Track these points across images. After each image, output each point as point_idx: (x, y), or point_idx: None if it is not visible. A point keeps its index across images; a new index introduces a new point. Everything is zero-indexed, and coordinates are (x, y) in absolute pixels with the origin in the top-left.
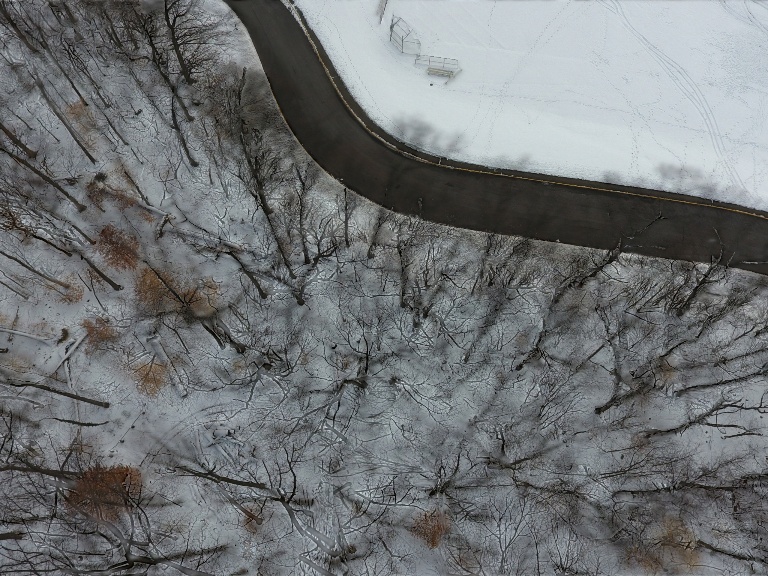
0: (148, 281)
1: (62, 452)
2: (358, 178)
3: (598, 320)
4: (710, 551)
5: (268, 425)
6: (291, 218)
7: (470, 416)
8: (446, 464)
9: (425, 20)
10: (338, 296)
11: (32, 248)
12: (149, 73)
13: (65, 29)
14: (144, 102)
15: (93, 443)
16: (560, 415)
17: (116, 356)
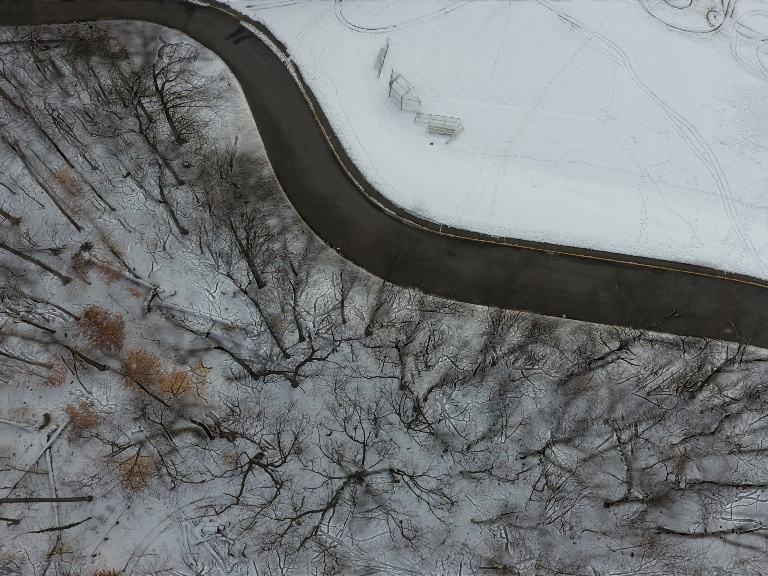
0: (134, 365)
1: (40, 564)
2: (355, 247)
3: (607, 405)
4: None
5: (259, 524)
6: (285, 293)
7: (472, 515)
8: (447, 574)
9: (425, 74)
10: (334, 378)
11: (11, 334)
12: (138, 133)
13: (49, 93)
14: (132, 164)
15: (74, 548)
16: (567, 509)
17: (100, 445)
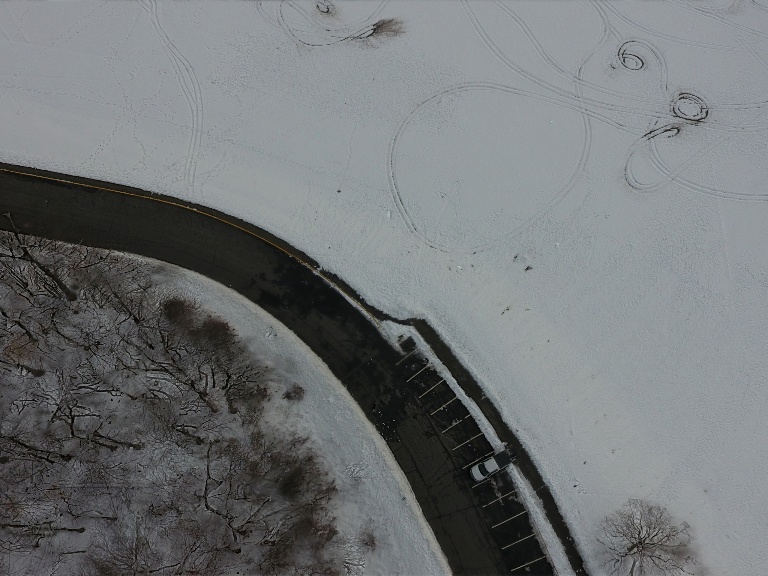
0: None
1: None
2: None
3: None
4: (3, 523)
5: None
6: None
7: None
8: None
9: None
10: None
11: None
12: None
13: None
14: None
15: None
16: None
17: None
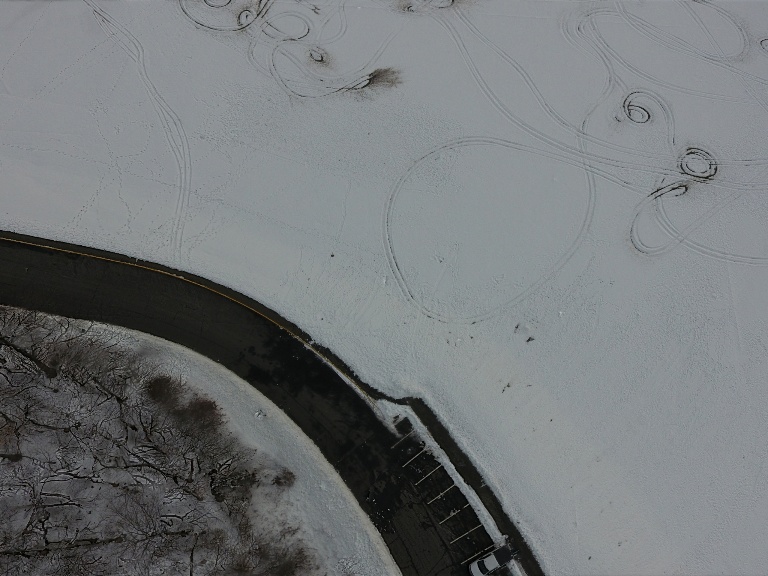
0: None
1: None
2: None
3: None
4: None
5: None
6: None
7: None
8: None
9: None
10: None
11: None
12: None
13: None
14: None
15: None
16: None
17: None
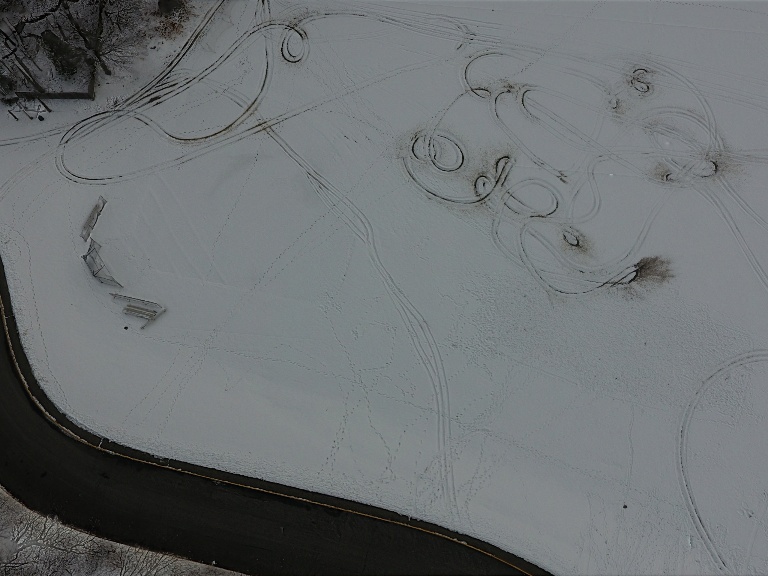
0: None
1: None
2: (1, 459)
3: None
4: None
5: None
6: None
7: None
8: None
9: (140, 238)
10: None
11: None
12: None
13: None
14: None
15: None
16: None
17: None
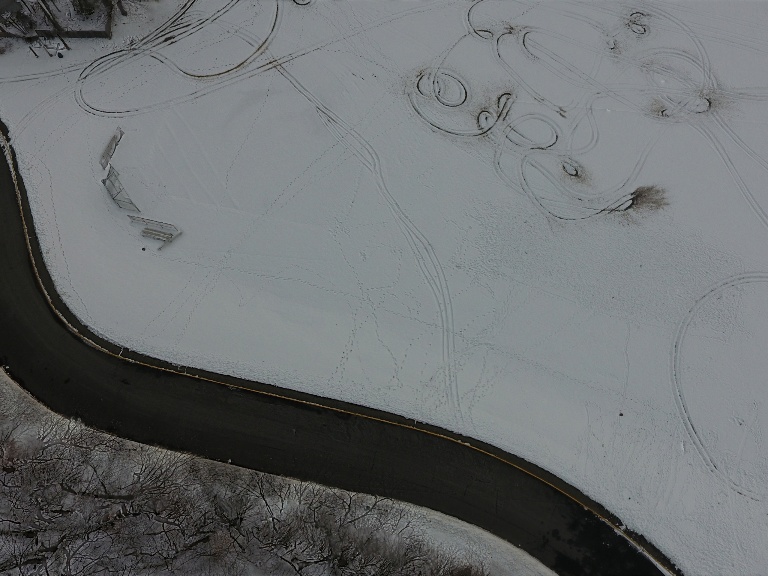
0: None
1: None
2: (26, 366)
3: (240, 573)
4: None
5: None
6: None
7: None
8: None
9: (157, 167)
10: None
11: None
12: None
13: None
14: None
15: None
16: None
17: None
